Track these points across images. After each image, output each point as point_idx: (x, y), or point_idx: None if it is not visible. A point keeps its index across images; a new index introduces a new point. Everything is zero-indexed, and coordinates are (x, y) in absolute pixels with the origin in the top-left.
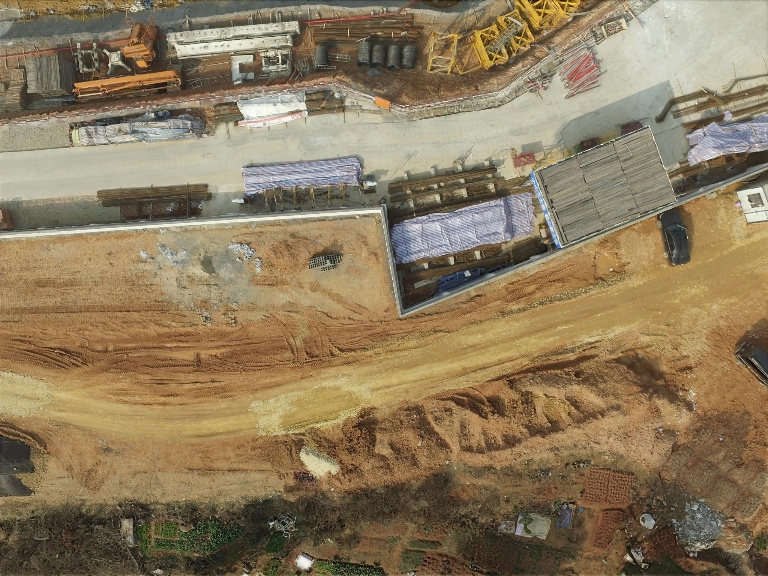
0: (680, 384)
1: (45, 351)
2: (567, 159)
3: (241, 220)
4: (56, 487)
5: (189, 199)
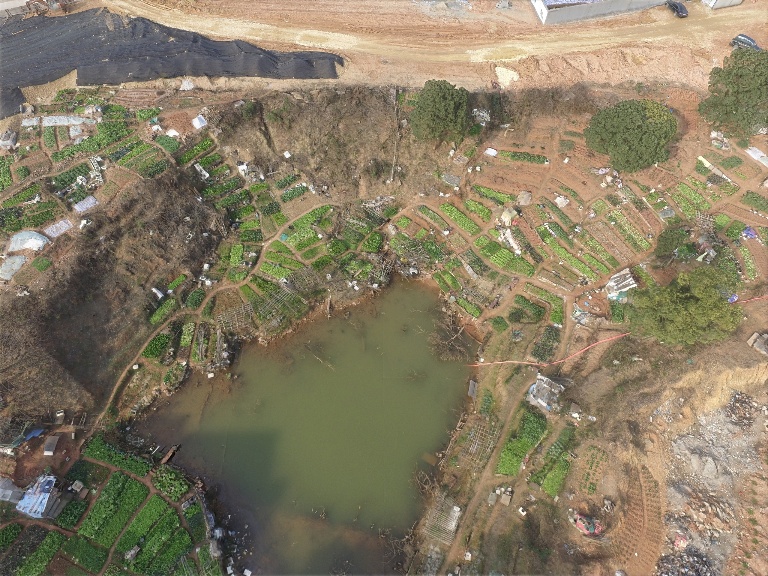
0: None
1: None
2: None
3: None
4: (352, 76)
5: None
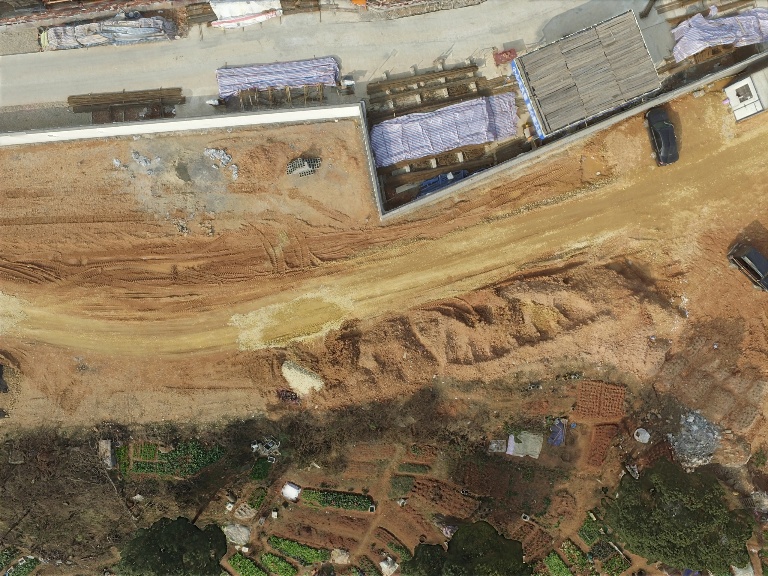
0: (672, 291)
1: (17, 266)
2: (548, 45)
3: (216, 123)
4: (31, 409)
5: (162, 103)
